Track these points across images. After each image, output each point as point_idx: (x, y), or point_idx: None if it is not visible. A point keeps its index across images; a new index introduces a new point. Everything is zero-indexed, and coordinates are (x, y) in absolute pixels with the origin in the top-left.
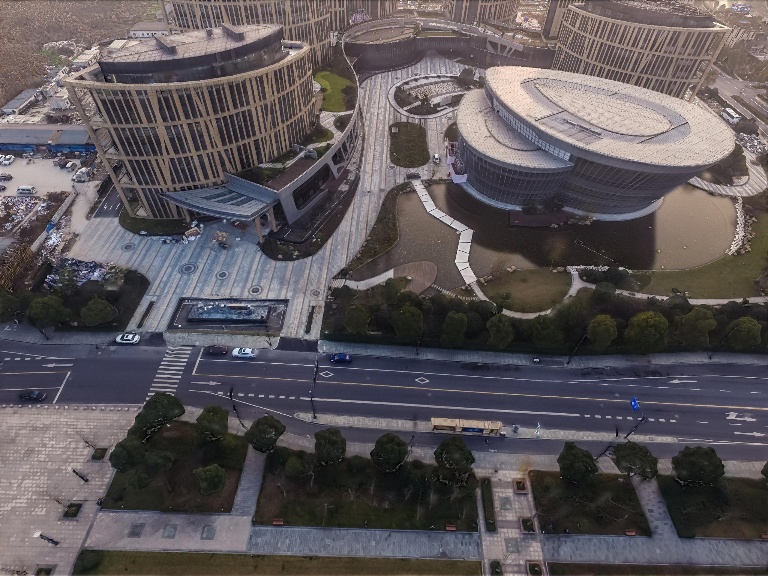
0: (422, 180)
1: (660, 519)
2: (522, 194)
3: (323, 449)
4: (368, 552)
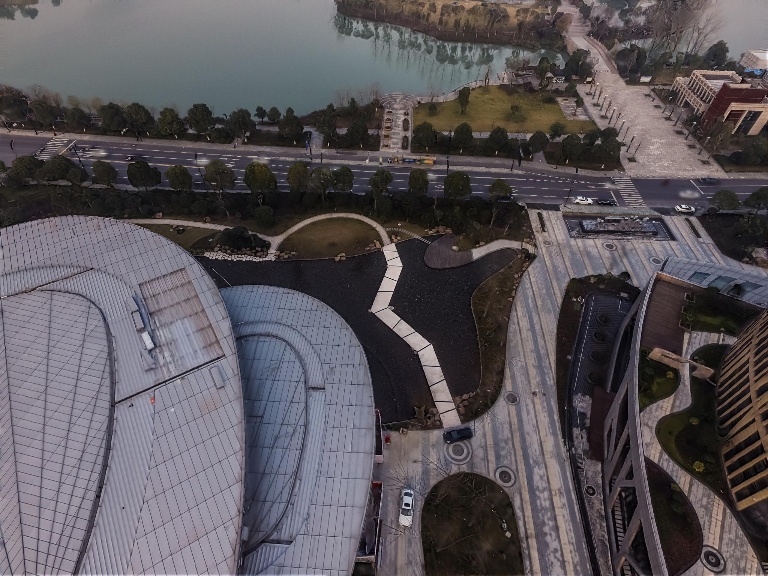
0: (441, 425)
1: (317, 137)
2: None
3: None
4: None
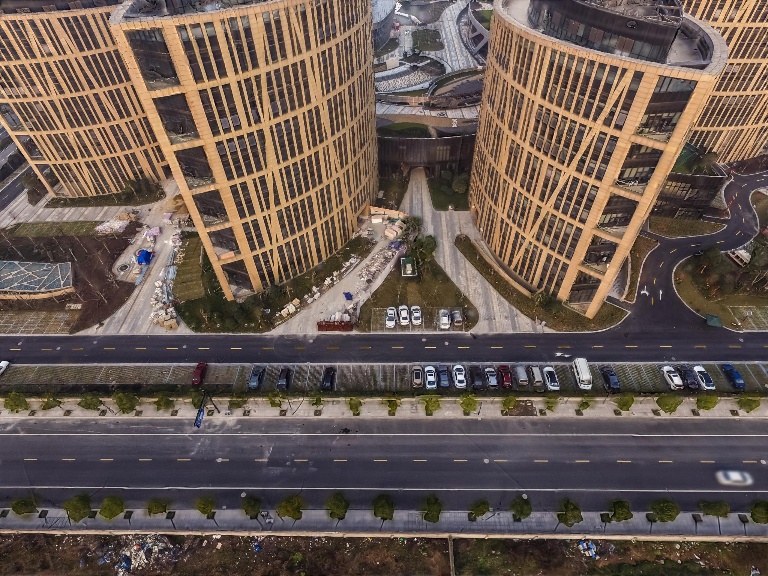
0: (417, 24)
1: None
2: None
3: None
4: None
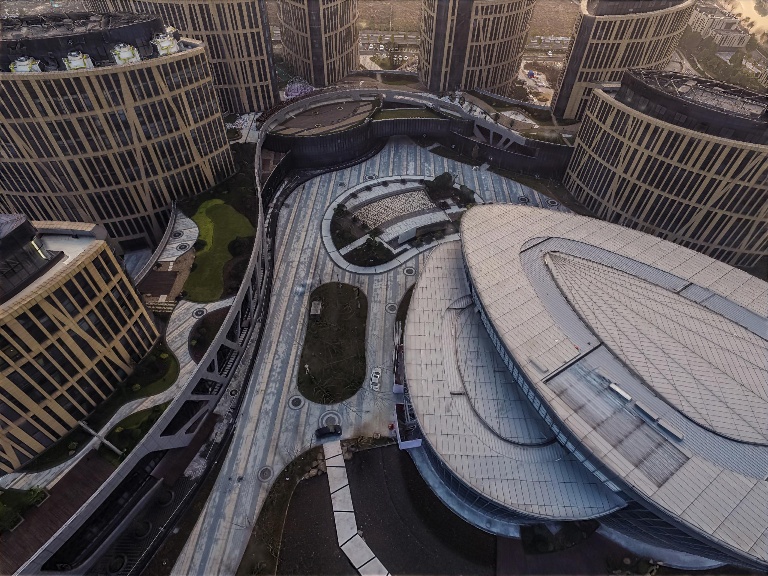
0: (342, 442)
1: None
2: (520, 520)
3: None
4: None
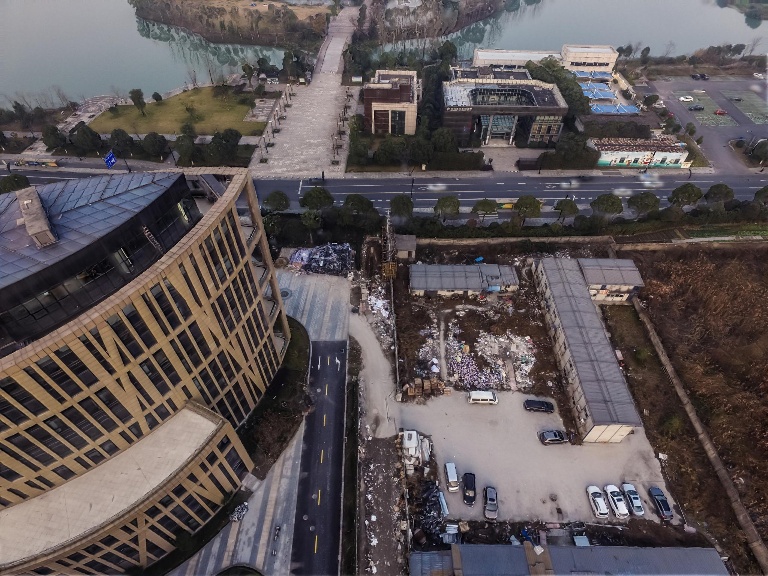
0: None
1: None
2: None
3: (123, 131)
4: None
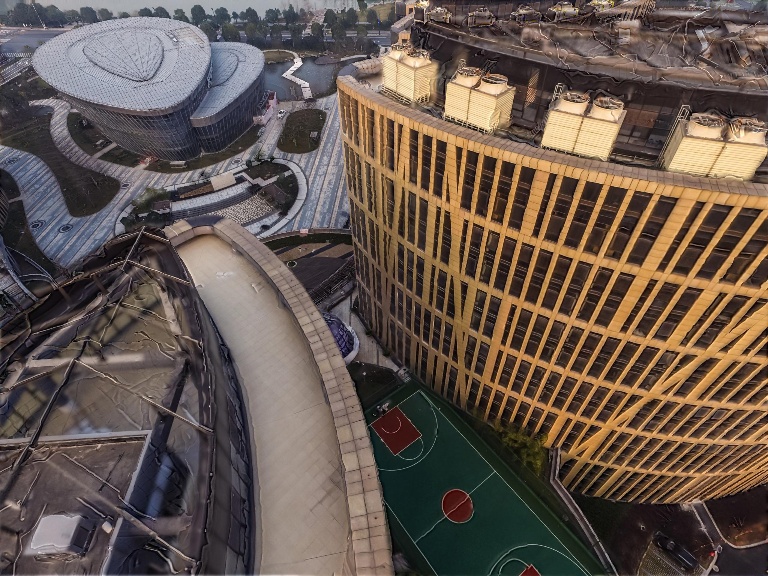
0: (304, 99)
1: None
2: None
3: None
4: (361, 22)
